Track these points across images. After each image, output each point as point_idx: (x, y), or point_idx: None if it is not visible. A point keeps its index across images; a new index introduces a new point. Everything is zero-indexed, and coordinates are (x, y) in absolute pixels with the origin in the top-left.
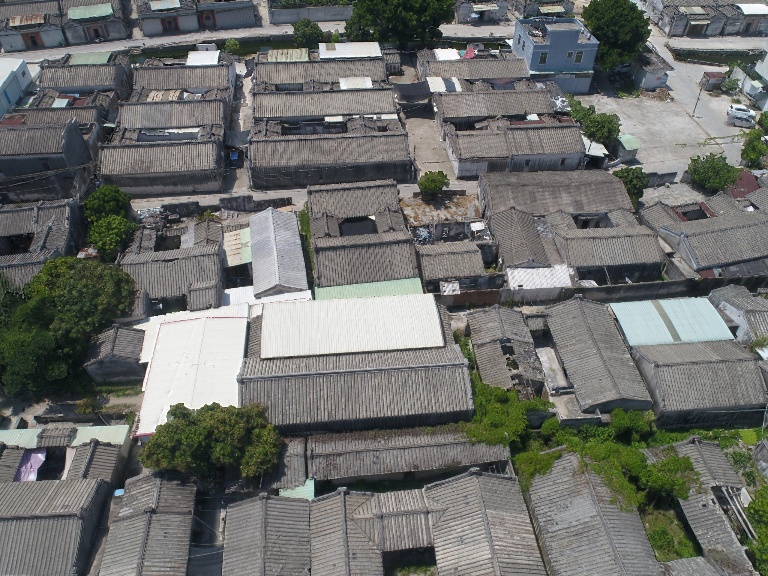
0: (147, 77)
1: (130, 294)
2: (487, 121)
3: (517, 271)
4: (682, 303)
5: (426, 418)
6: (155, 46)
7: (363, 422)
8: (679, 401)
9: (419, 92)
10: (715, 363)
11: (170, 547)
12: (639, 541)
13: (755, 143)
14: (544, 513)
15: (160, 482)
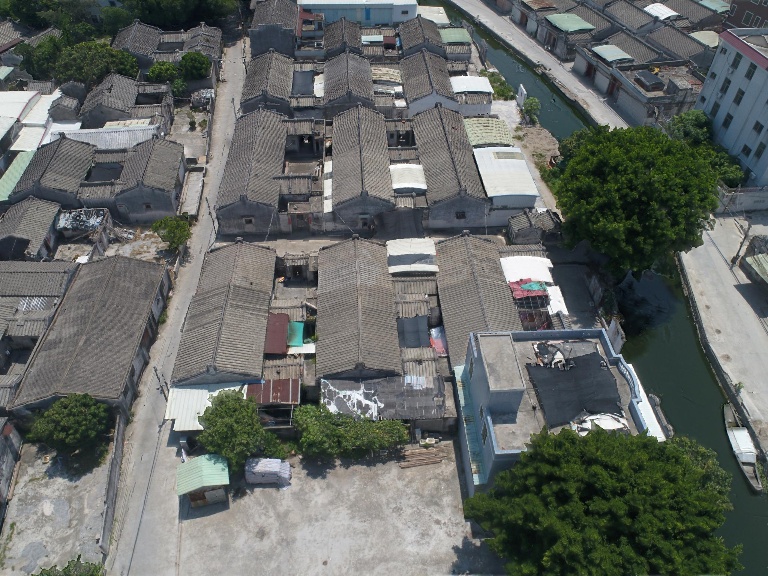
0: (414, 61)
1: None
2: None
3: None
4: None
5: None
6: (550, 76)
7: None
8: None
9: (394, 233)
10: None
11: None
12: None
13: None
14: None
15: None
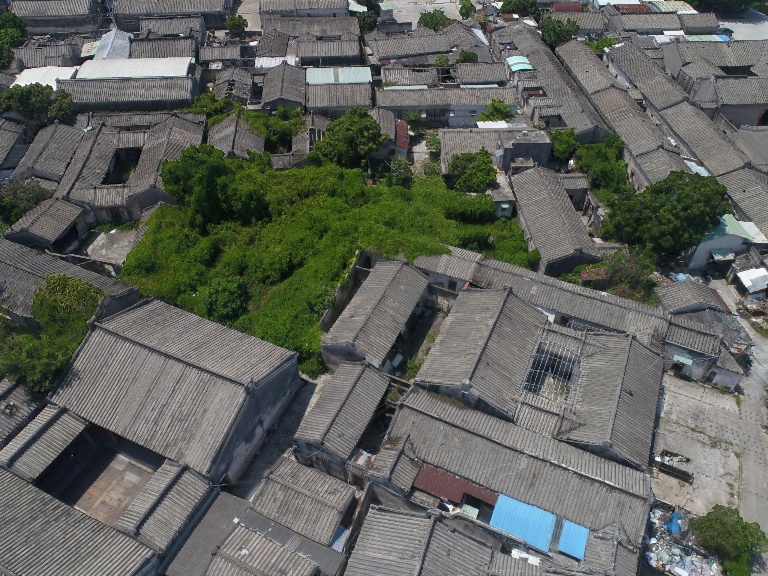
0: None
1: (10, 58)
2: None
3: (262, 58)
4: (352, 68)
5: (164, 105)
6: None
7: (127, 105)
8: (317, 103)
9: None
10: (344, 85)
11: (3, 140)
12: (254, 143)
13: (464, 1)
14: (211, 137)
15: (4, 120)
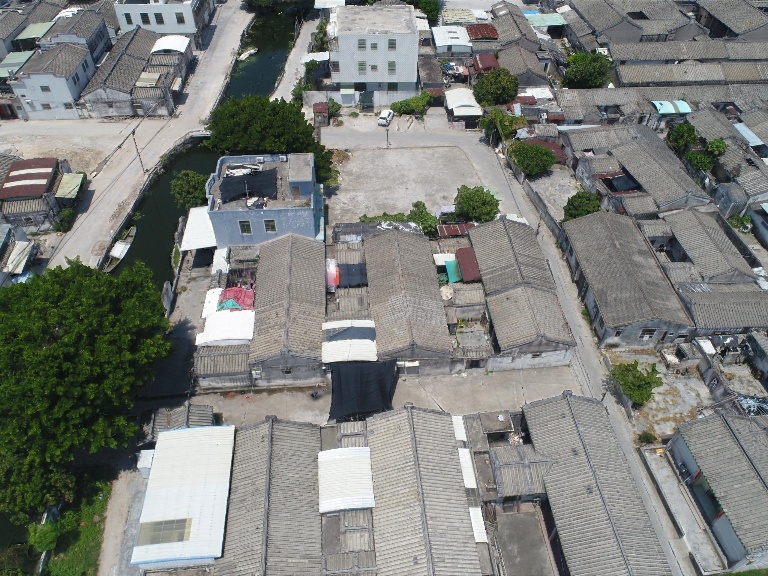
0: None
1: None
2: (450, 307)
3: None
4: None
5: None
6: None
7: None
8: None
9: (368, 379)
10: None
11: None
12: None
13: (505, 119)
14: None
15: None
